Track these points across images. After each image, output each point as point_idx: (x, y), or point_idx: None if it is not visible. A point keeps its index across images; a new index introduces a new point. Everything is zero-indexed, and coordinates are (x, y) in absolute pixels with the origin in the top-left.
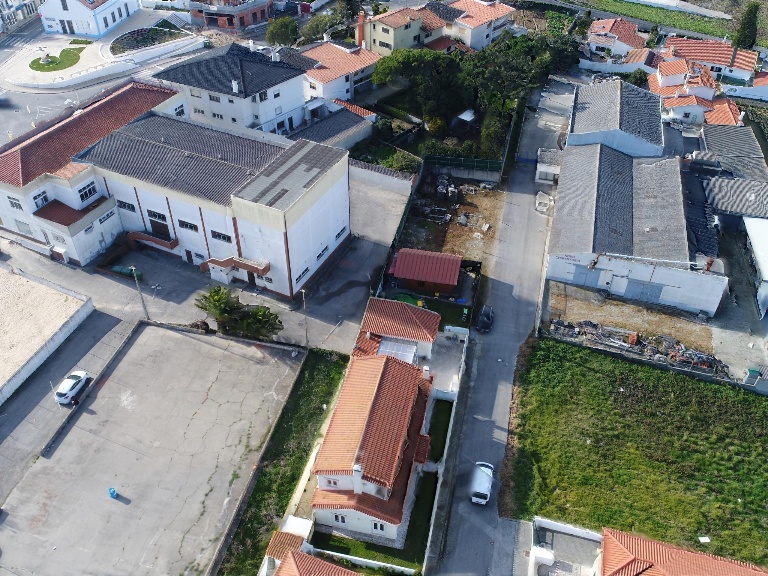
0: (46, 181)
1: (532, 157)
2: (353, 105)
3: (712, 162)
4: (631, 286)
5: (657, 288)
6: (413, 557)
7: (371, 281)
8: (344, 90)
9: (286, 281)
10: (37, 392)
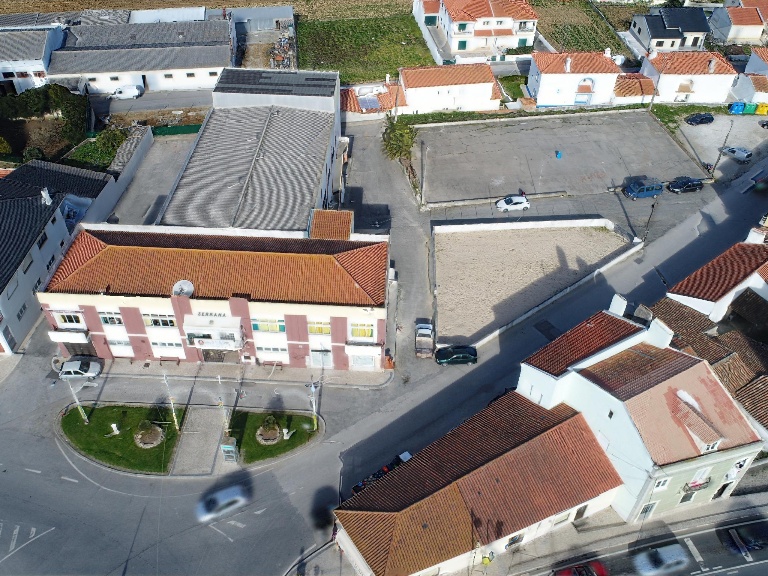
0: None
1: None
2: None
3: None
4: (234, 53)
5: None
6: None
7: None
8: None
9: None
10: None
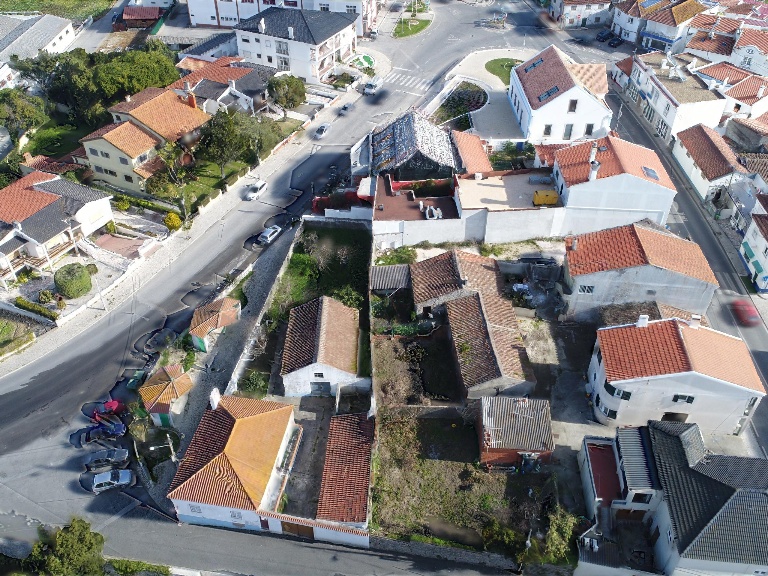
0: None
1: None
2: None
3: None
4: None
5: None
6: None
7: None
8: None
9: None
10: None
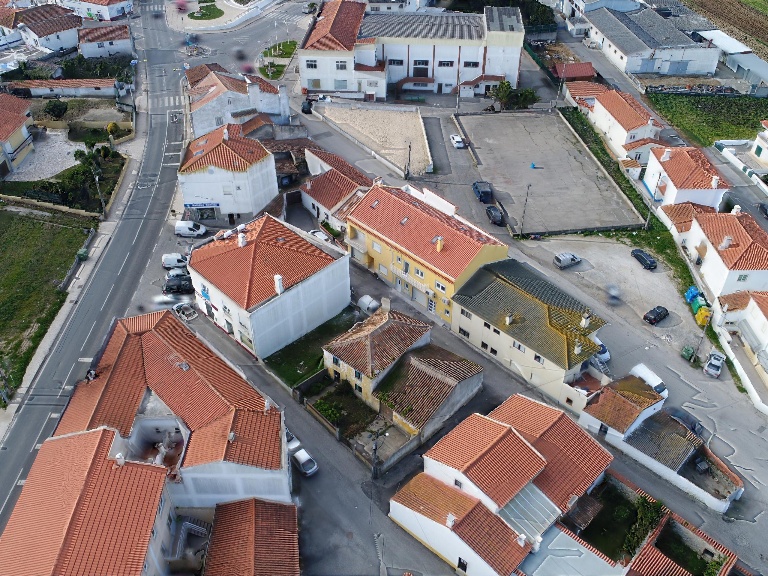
0: (355, 49)
1: (562, 25)
2: None
3: (666, 8)
4: (672, 66)
5: (685, 64)
6: None
7: (545, 84)
8: (425, 4)
9: (515, 84)
10: (439, 147)
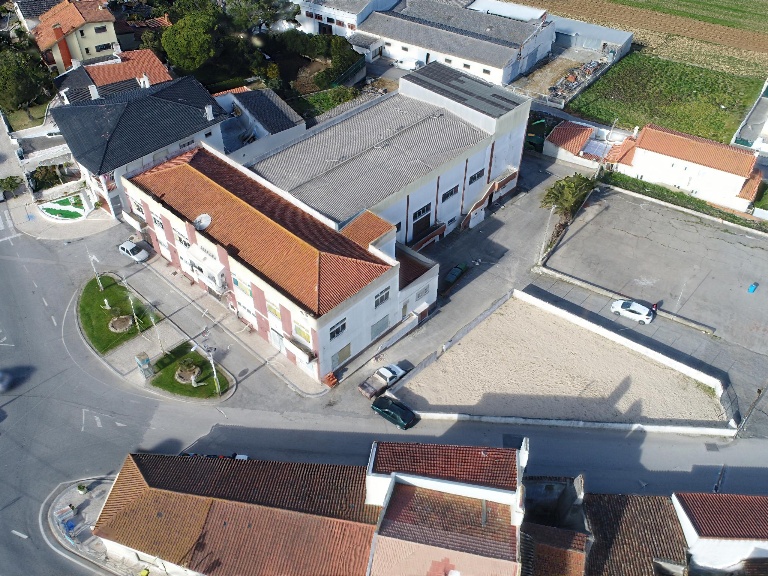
0: None
1: None
2: (214, 95)
3: None
4: None
5: None
6: (765, 184)
7: None
8: None
9: None
10: (634, 339)
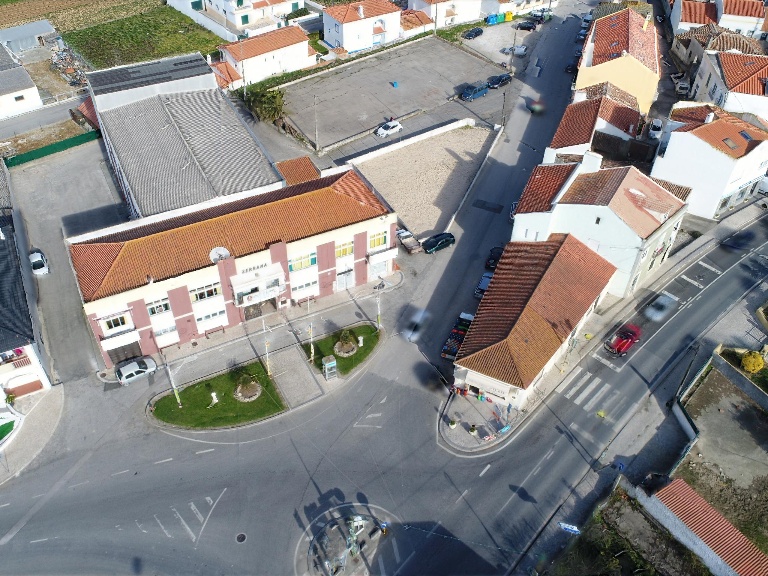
0: None
1: None
2: None
3: None
4: None
5: None
6: None
7: None
8: None
9: None
10: None
